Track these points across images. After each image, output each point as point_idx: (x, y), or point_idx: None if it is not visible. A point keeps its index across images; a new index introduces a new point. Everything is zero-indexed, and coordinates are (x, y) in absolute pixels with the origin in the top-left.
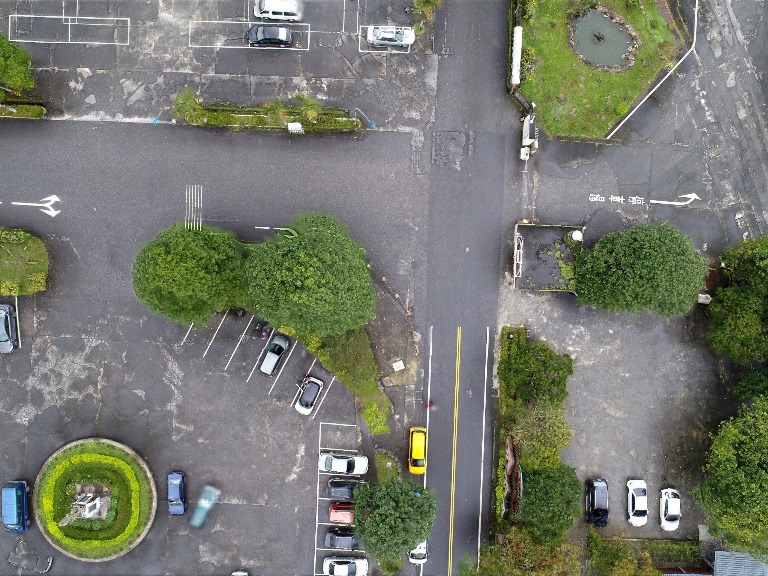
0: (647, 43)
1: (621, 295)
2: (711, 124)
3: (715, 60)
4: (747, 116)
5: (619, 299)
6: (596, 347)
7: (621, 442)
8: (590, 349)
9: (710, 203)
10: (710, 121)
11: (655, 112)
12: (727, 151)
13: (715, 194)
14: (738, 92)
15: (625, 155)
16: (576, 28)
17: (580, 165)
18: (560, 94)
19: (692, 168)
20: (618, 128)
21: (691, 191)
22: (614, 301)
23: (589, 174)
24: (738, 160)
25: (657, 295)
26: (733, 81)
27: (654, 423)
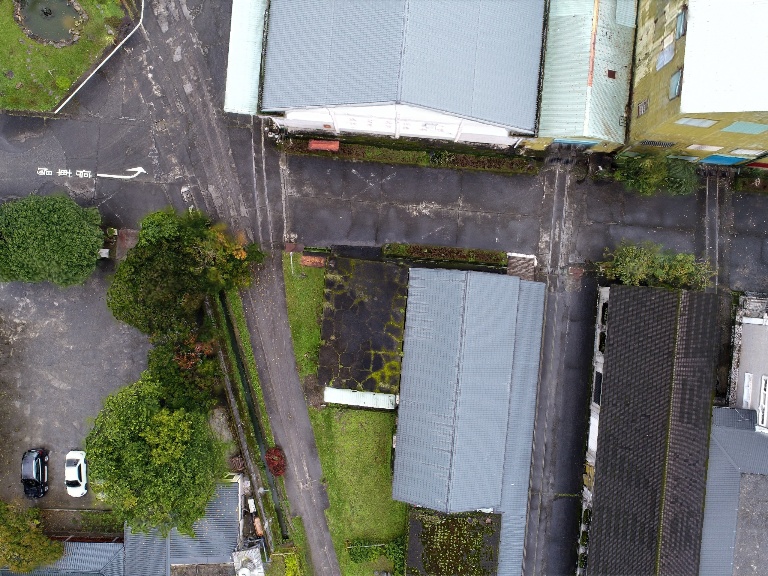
0: (94, 18)
1: (6, 265)
2: (158, 98)
3: (162, 35)
4: (193, 90)
5: (4, 269)
6: (42, 319)
7: (65, 413)
8: (35, 321)
9: (156, 177)
10: (157, 95)
11: (102, 86)
12: (173, 125)
13: (161, 168)
14: (184, 67)
15: (73, 129)
16: (26, 3)
17: (28, 139)
18: (3, 68)
19: (139, 142)
20: (66, 102)
21: (138, 165)
22: (1, 271)
23: (37, 148)
24: (184, 134)
25: (35, 264)
26: (179, 56)
27: (97, 395)
